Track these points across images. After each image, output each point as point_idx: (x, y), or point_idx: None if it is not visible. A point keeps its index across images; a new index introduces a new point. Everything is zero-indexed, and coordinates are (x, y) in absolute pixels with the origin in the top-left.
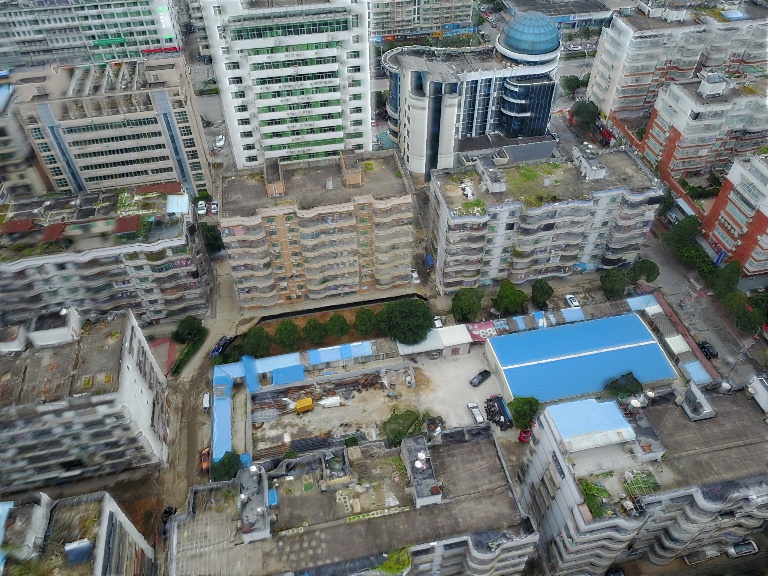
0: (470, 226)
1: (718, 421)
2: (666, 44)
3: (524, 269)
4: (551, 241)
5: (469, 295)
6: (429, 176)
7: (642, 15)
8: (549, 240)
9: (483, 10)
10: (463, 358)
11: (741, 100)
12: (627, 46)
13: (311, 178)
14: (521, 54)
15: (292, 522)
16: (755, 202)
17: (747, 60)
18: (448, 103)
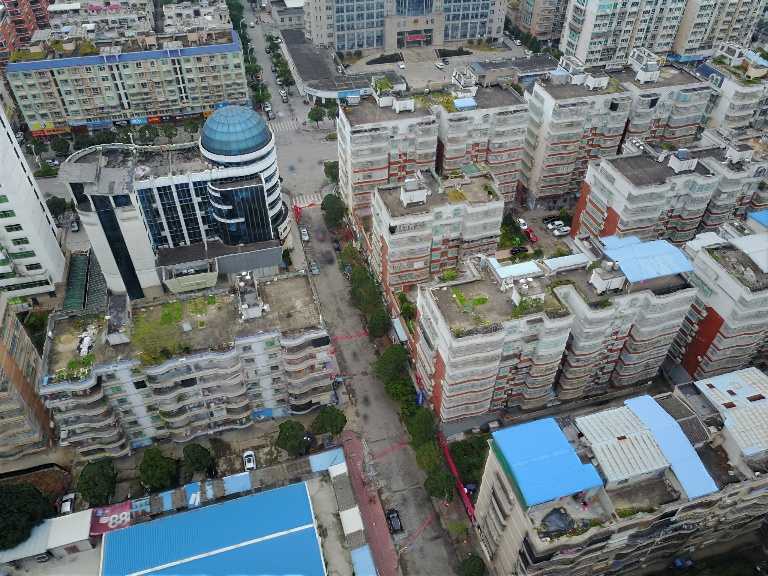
0: (72, 393)
1: None
2: (394, 137)
3: (181, 428)
4: (203, 396)
5: (87, 476)
6: (135, 293)
7: (373, 104)
8: (199, 395)
9: (279, 83)
10: (83, 557)
11: (446, 208)
12: (349, 141)
13: None
14: (218, 155)
15: None
16: (433, 341)
17: (492, 150)
18: (125, 216)
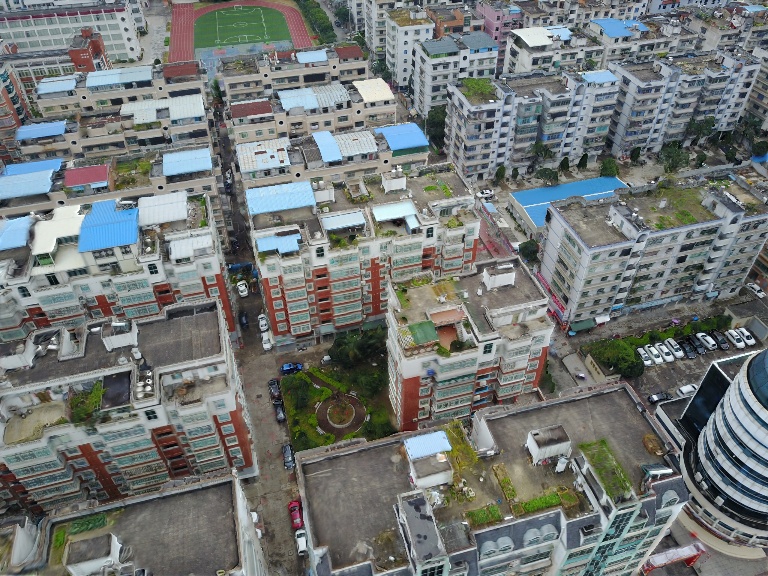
0: None
1: (531, 91)
2: None
3: None
4: None
5: None
6: None
7: None
8: None
9: None
10: None
11: None
12: None
13: None
14: None
15: (709, 63)
16: None
17: None
18: None
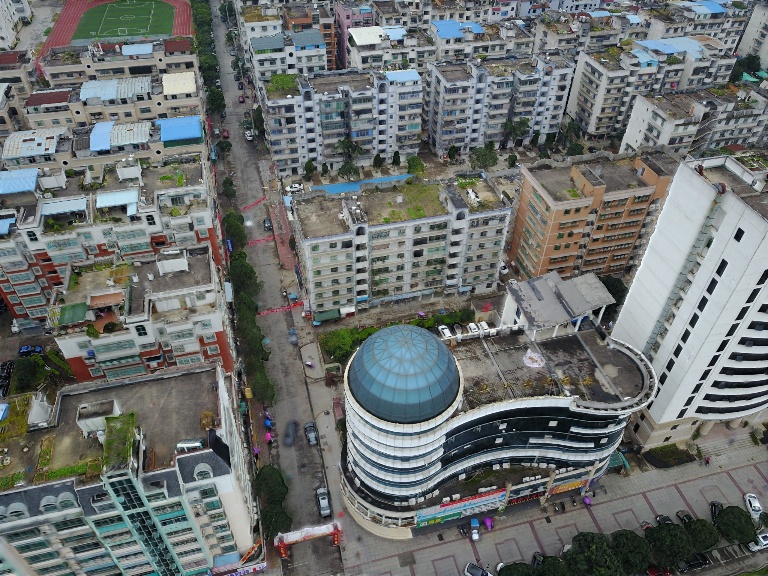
0: None
1: (336, 88)
2: None
3: None
4: None
5: None
6: None
7: (153, 448)
8: None
9: None
10: None
11: None
12: None
13: (620, 183)
14: None
15: None
16: None
17: None
18: None
